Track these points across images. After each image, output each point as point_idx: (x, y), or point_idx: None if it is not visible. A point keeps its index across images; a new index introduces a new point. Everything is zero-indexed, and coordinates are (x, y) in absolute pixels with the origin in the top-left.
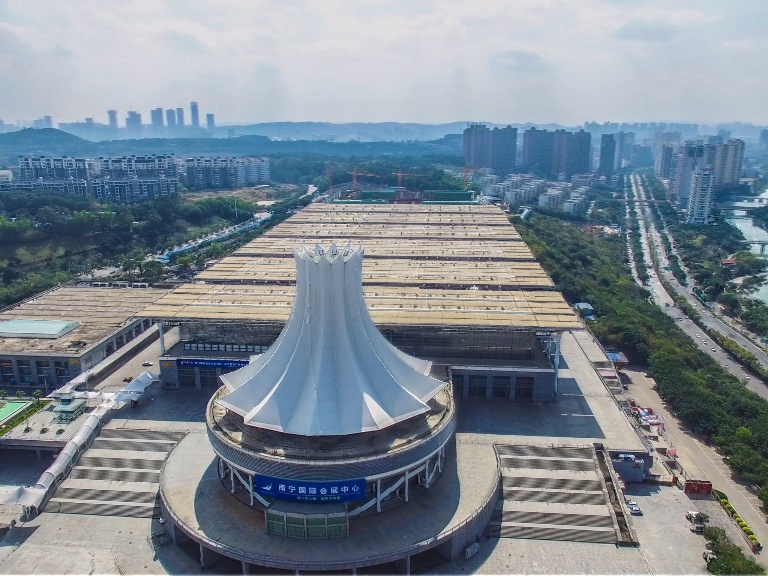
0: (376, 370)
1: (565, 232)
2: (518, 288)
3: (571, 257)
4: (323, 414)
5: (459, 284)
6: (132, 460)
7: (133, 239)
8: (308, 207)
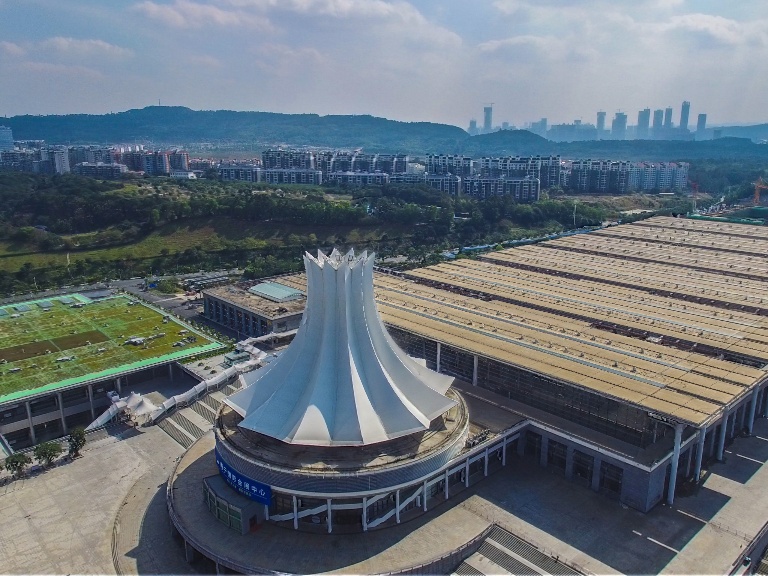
0: (346, 387)
1: None
2: (720, 353)
3: None
4: (270, 412)
5: (643, 330)
6: None
7: (449, 233)
8: (646, 220)
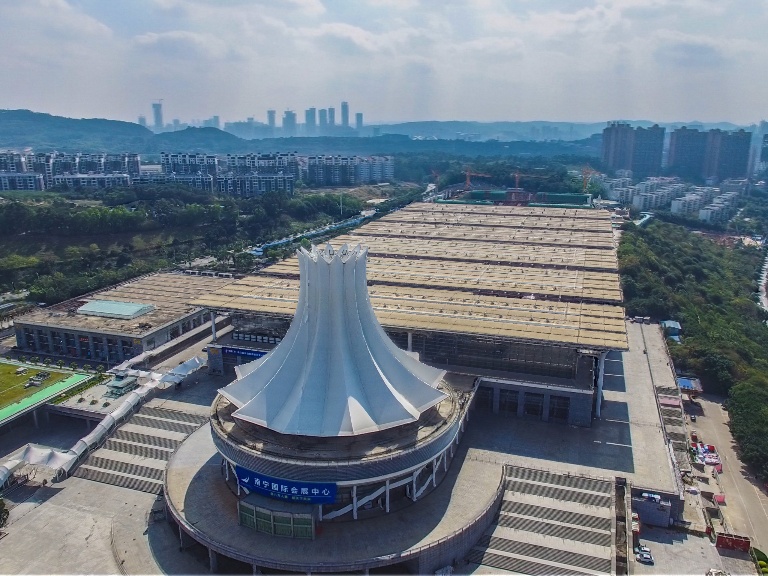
0: (370, 374)
1: (689, 242)
2: (580, 300)
3: (684, 269)
4: (305, 414)
5: (516, 292)
6: (158, 438)
7: (237, 231)
8: (408, 206)
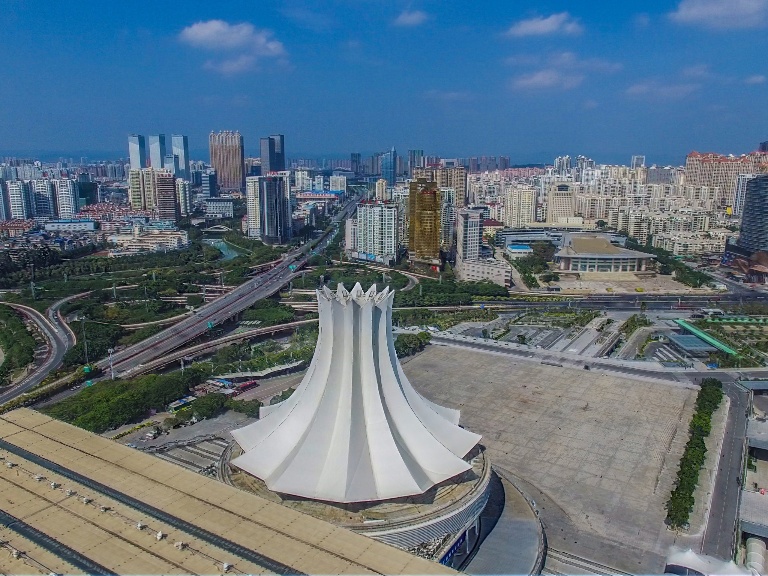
0: None
1: None
2: None
3: None
4: None
5: None
6: None
7: None
8: None
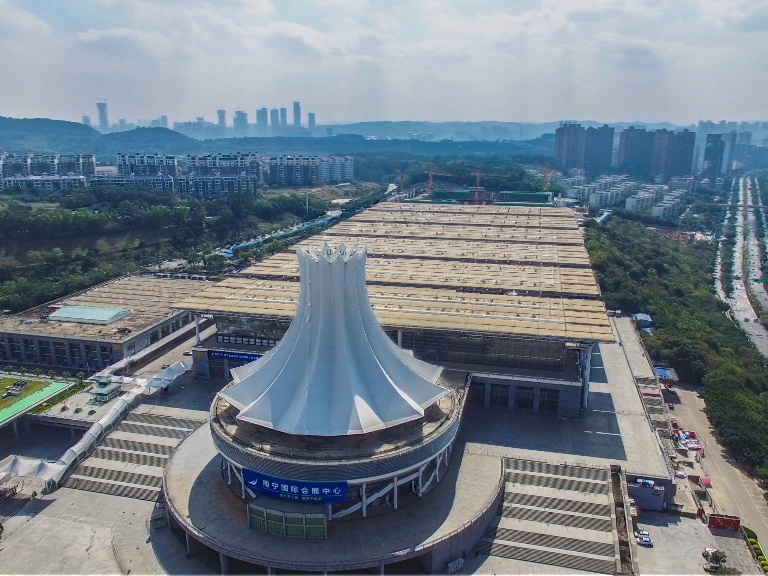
0: (373, 373)
1: (646, 238)
2: (560, 295)
3: (645, 264)
4: (312, 414)
5: (498, 288)
6: (149, 444)
7: (204, 233)
8: (376, 206)
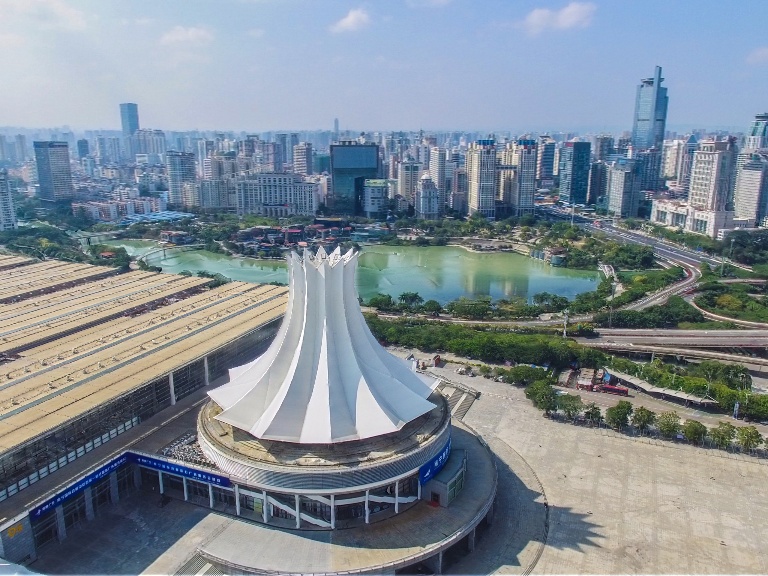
0: None
1: None
2: (197, 289)
3: None
4: None
5: (152, 301)
6: None
7: None
8: None
